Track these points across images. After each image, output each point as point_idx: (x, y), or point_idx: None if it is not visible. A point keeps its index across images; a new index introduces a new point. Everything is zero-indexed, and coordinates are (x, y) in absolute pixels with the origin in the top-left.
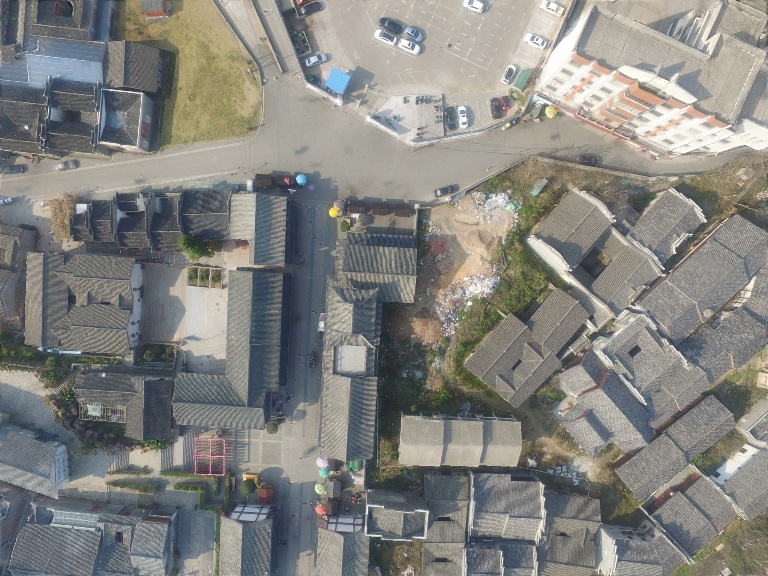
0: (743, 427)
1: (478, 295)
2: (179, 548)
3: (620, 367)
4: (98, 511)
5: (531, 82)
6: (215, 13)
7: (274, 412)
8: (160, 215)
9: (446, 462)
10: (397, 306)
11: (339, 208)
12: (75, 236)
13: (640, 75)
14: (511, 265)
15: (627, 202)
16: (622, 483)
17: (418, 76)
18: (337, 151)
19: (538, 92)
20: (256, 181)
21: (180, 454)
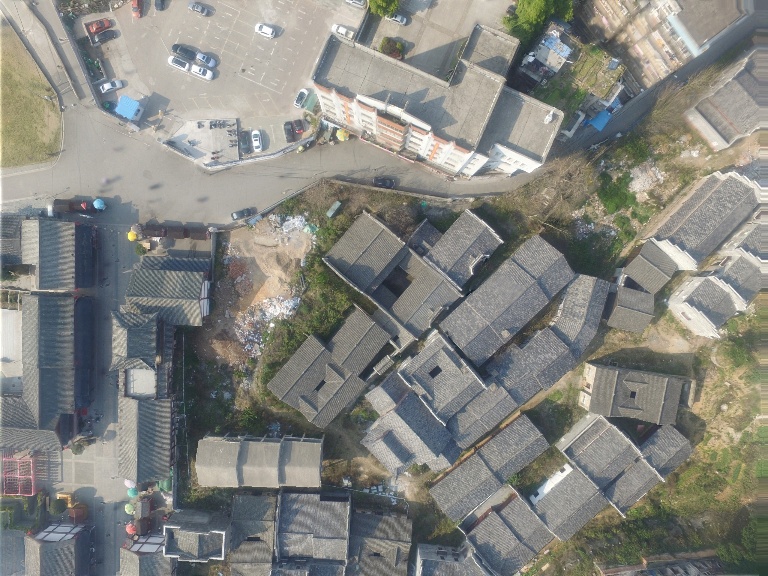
0: (560, 447)
1: (279, 317)
2: None
3: (419, 388)
4: None
5: None
6: (17, 42)
7: (84, 433)
8: None
9: (246, 483)
10: (200, 328)
11: (136, 232)
12: None
13: (374, 103)
14: (310, 287)
15: (429, 223)
16: None
17: (213, 101)
18: (137, 175)
19: (325, 116)
20: (54, 206)
21: None
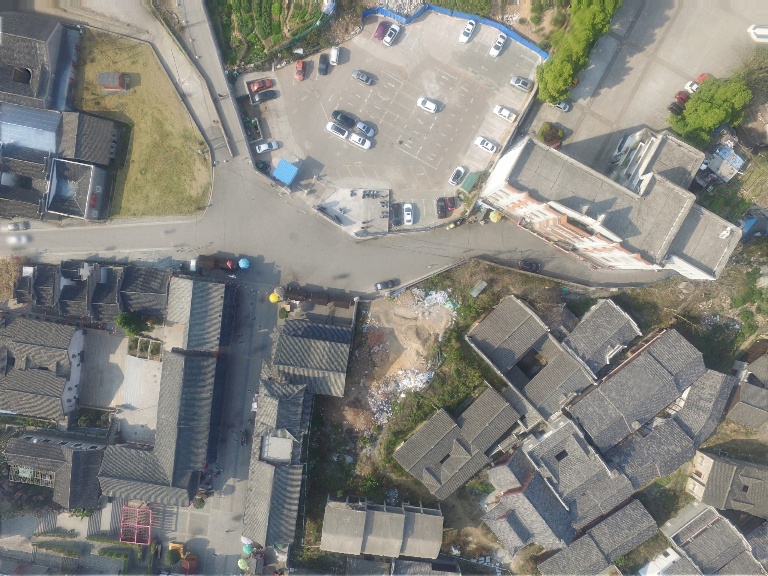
0: (667, 532)
1: (411, 388)
2: None
3: (545, 471)
4: (20, 573)
5: (478, 186)
6: (171, 91)
7: (203, 485)
8: (103, 286)
9: (366, 551)
10: None
11: (279, 295)
12: (19, 299)
13: (568, 212)
14: (446, 362)
15: (567, 307)
16: None
17: (367, 170)
18: (282, 237)
19: (482, 198)
20: (199, 262)
21: (108, 520)
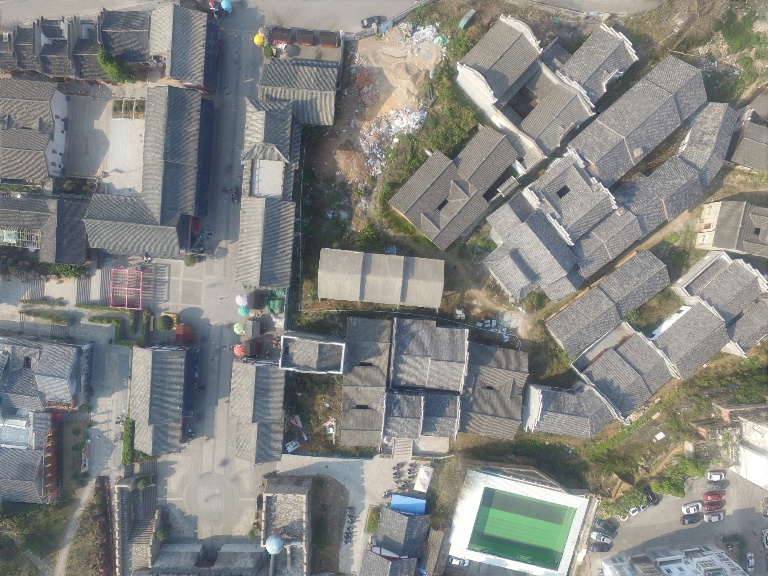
0: (679, 285)
1: (404, 130)
2: (93, 385)
3: (547, 206)
4: (8, 336)
5: None
6: None
7: (195, 249)
8: (85, 41)
9: (366, 298)
10: (322, 140)
11: (263, 34)
12: None
13: None
14: (438, 100)
15: None
16: (554, 343)
17: None
18: None
19: None
20: (180, 5)
21: (97, 288)
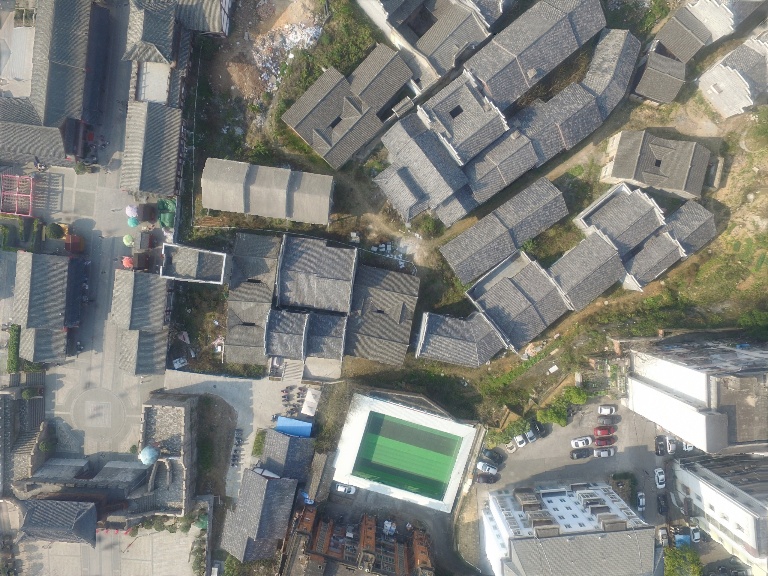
0: (578, 217)
1: (299, 45)
2: None
3: (439, 125)
4: None
5: None
6: None
7: (89, 159)
8: None
9: (251, 210)
10: (217, 54)
11: None
12: None
13: None
14: (334, 16)
15: None
16: (452, 272)
17: None
18: None
19: None
20: None
21: None
